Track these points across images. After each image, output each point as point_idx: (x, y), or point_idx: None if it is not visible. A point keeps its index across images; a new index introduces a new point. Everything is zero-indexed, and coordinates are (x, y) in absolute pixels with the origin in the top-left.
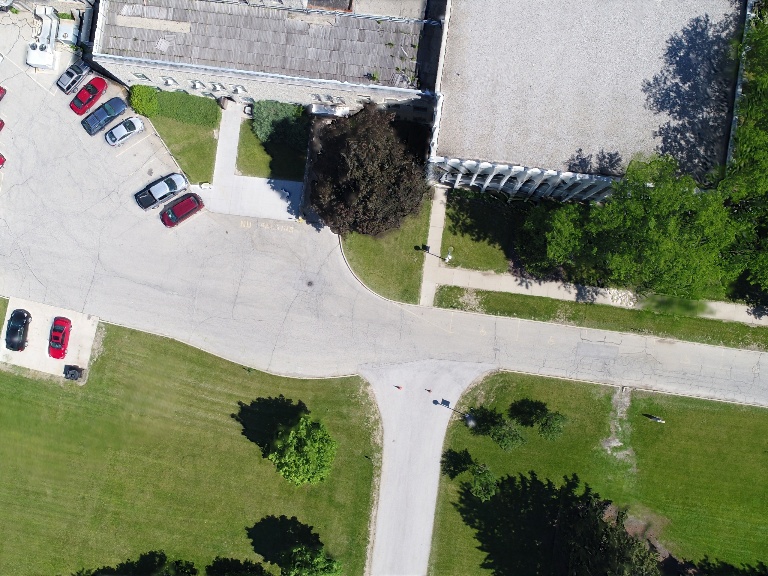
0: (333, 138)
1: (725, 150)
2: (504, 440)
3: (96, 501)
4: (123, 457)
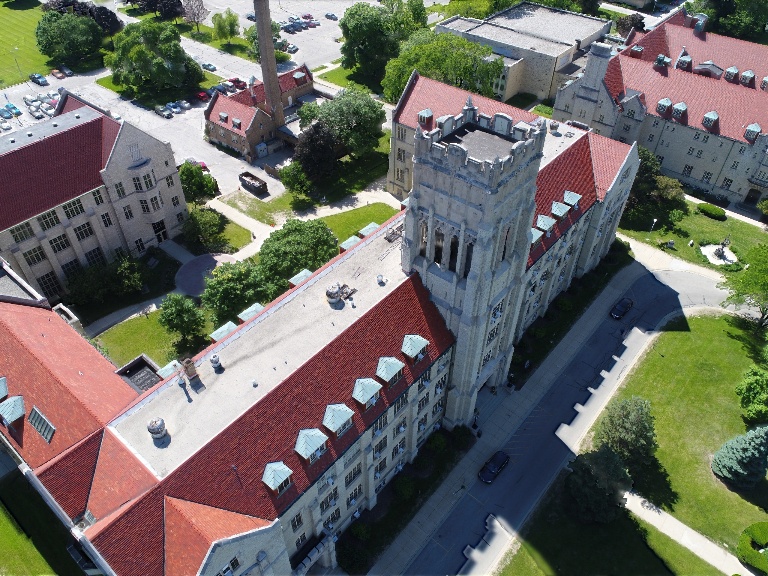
0: (643, 32)
1: (518, 6)
2: (605, 17)
3: None
4: None
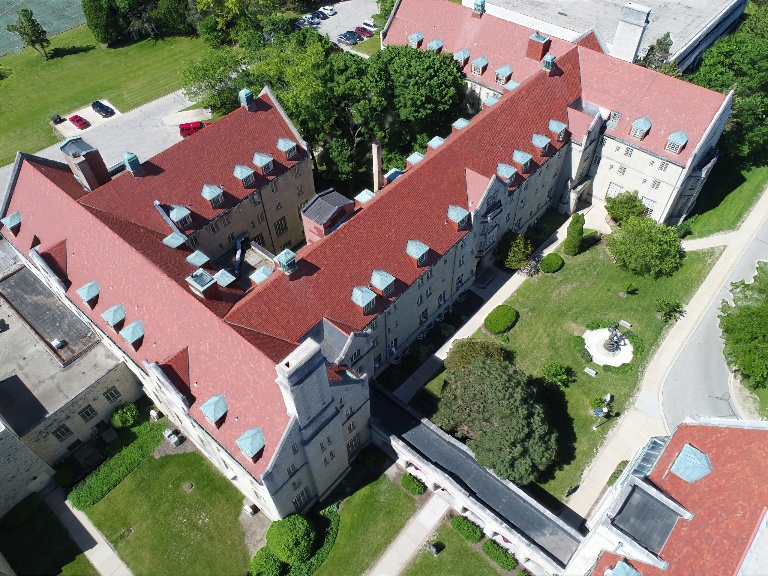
0: None
1: None
2: None
3: (4, 108)
4: (4, 123)
